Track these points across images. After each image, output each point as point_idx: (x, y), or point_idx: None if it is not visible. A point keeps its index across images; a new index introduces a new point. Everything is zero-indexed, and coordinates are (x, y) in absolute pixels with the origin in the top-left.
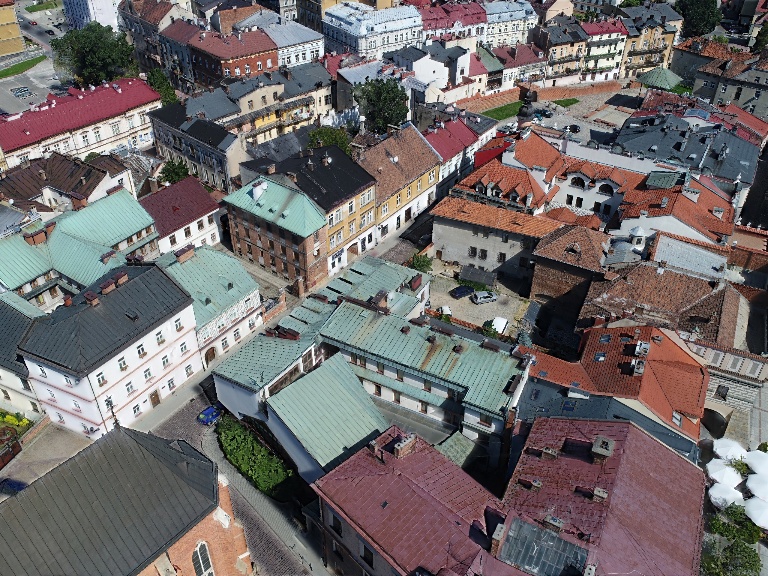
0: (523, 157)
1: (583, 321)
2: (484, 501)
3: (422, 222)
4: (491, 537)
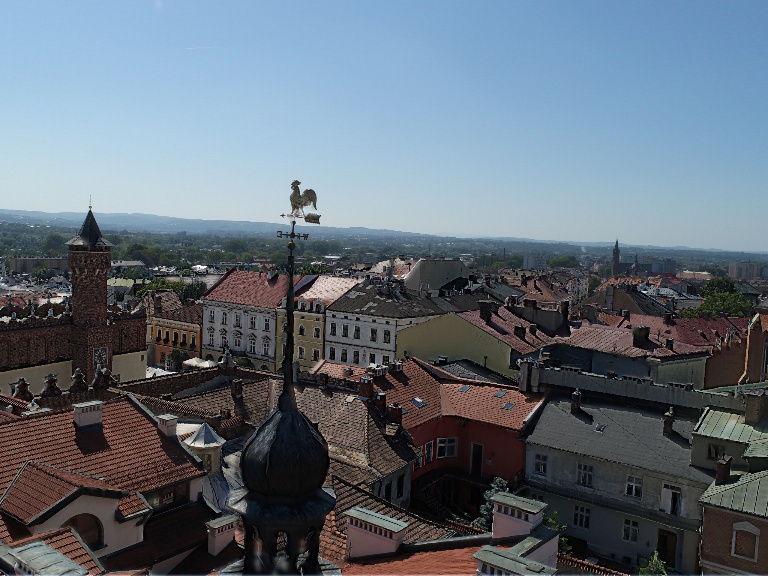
0: (437, 568)
1: (405, 453)
2: None
3: None
4: (567, 325)
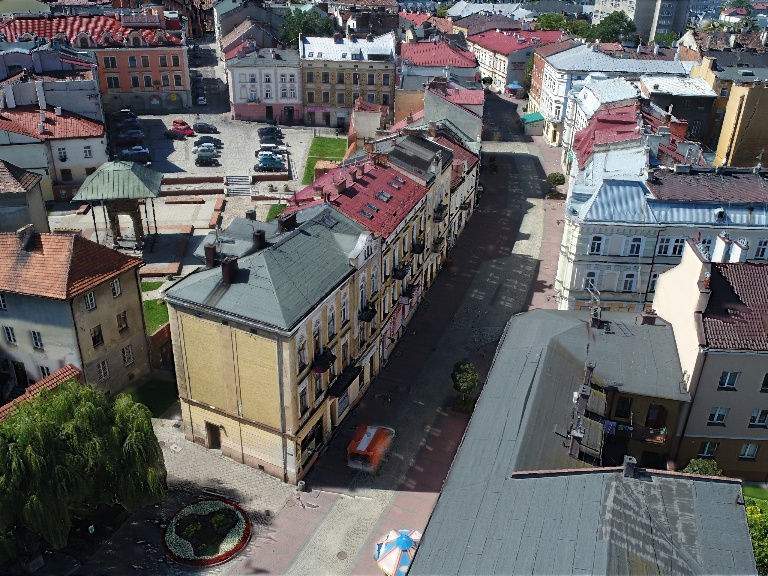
0: None
1: None
2: (60, 2)
3: (220, 84)
4: None
